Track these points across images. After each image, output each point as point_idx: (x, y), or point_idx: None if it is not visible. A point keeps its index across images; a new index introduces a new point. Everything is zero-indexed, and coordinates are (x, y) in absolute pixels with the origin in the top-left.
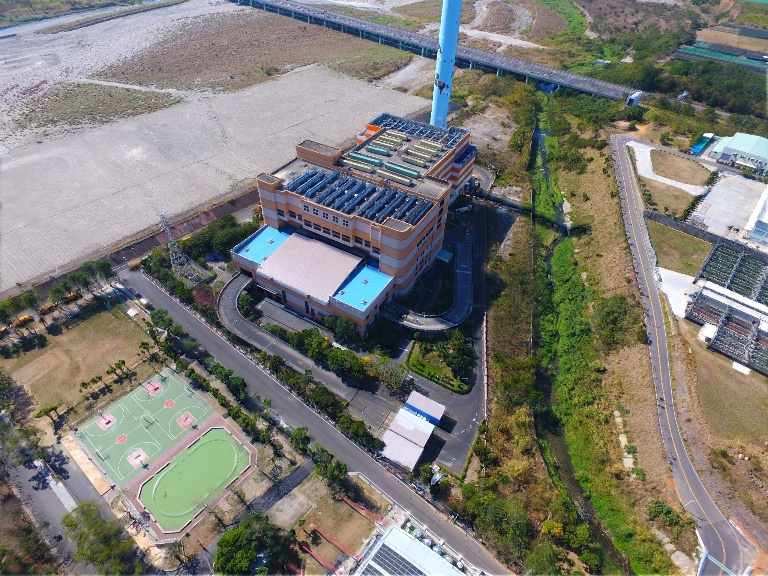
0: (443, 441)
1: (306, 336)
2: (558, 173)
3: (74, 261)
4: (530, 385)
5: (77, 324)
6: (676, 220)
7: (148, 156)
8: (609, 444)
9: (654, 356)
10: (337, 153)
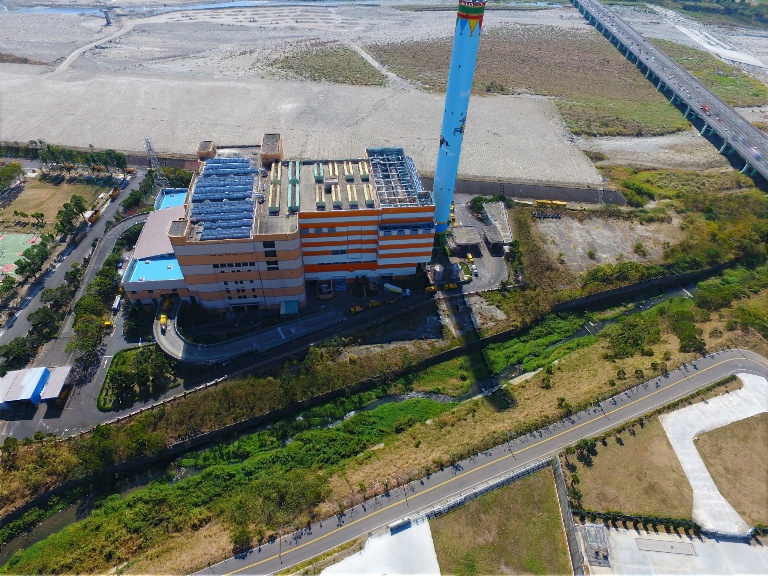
0: (31, 417)
1: (101, 274)
2: (599, 341)
3: (140, 151)
4: (100, 447)
5: (80, 184)
6: (569, 506)
7: (289, 112)
8: (71, 572)
9: (216, 570)
10: (271, 154)
